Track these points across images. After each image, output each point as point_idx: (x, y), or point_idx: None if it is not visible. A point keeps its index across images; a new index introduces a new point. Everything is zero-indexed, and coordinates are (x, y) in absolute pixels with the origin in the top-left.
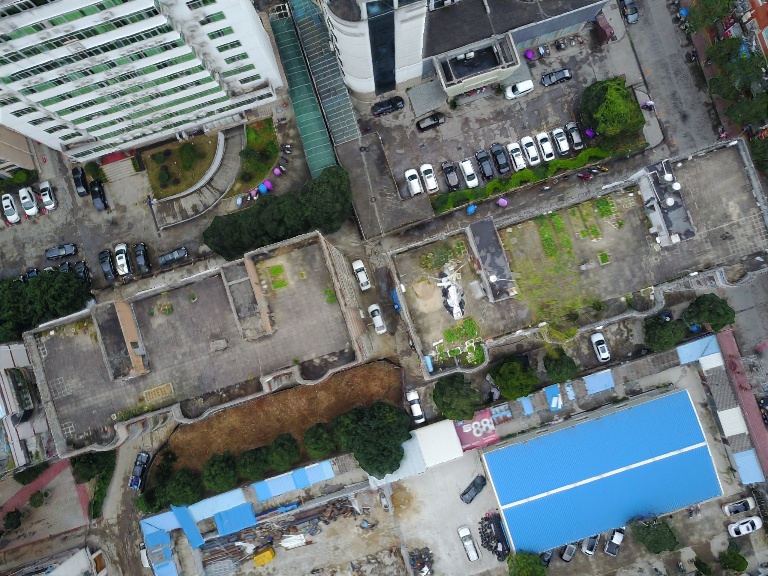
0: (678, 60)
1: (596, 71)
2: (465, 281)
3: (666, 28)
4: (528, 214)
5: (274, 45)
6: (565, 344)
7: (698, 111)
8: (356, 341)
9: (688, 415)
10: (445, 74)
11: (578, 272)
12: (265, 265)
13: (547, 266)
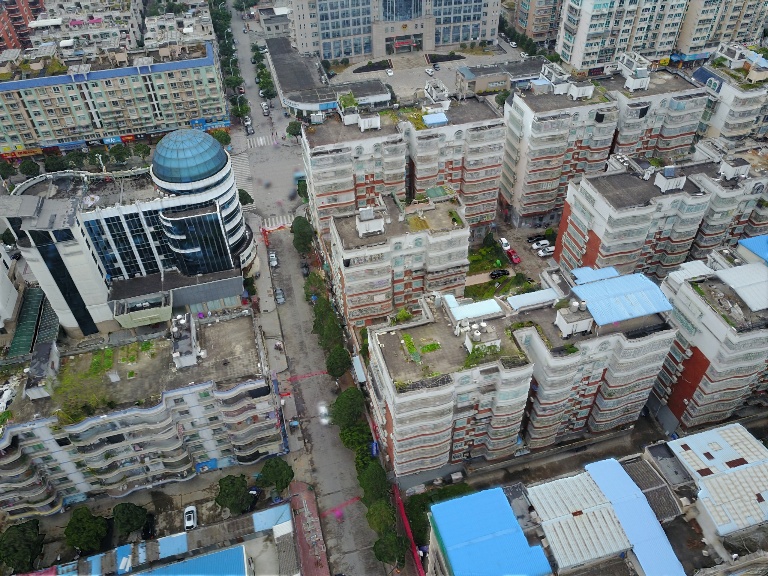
0: (308, 324)
1: None
2: (21, 388)
3: (304, 307)
4: None
5: (19, 298)
6: (162, 517)
7: (317, 353)
8: None
9: (238, 570)
10: (121, 311)
11: (109, 383)
12: None
13: (81, 373)
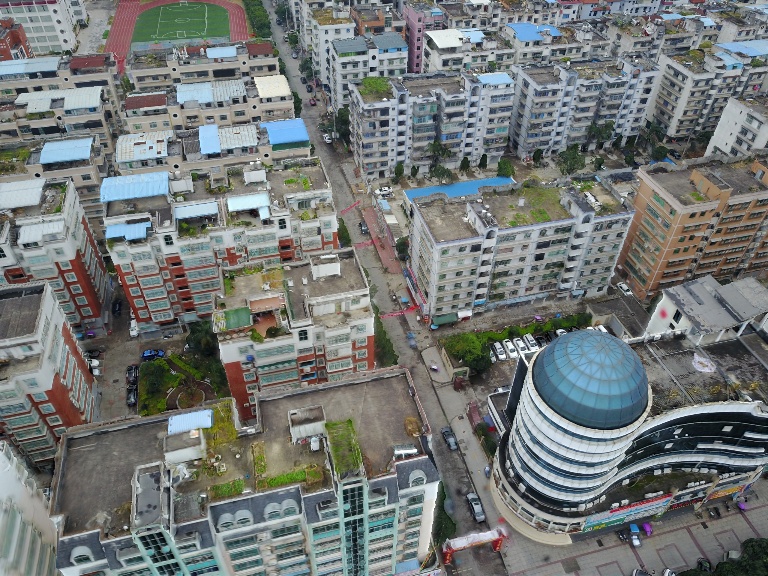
0: None
1: (474, 396)
2: None
3: None
4: (557, 227)
5: None
6: None
7: None
8: (642, 179)
9: None
10: None
11: None
12: (706, 201)
13: (546, 200)
